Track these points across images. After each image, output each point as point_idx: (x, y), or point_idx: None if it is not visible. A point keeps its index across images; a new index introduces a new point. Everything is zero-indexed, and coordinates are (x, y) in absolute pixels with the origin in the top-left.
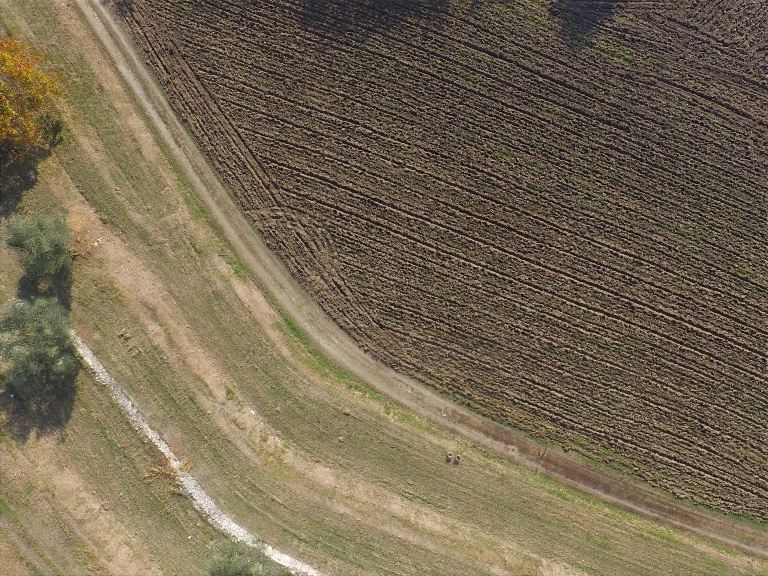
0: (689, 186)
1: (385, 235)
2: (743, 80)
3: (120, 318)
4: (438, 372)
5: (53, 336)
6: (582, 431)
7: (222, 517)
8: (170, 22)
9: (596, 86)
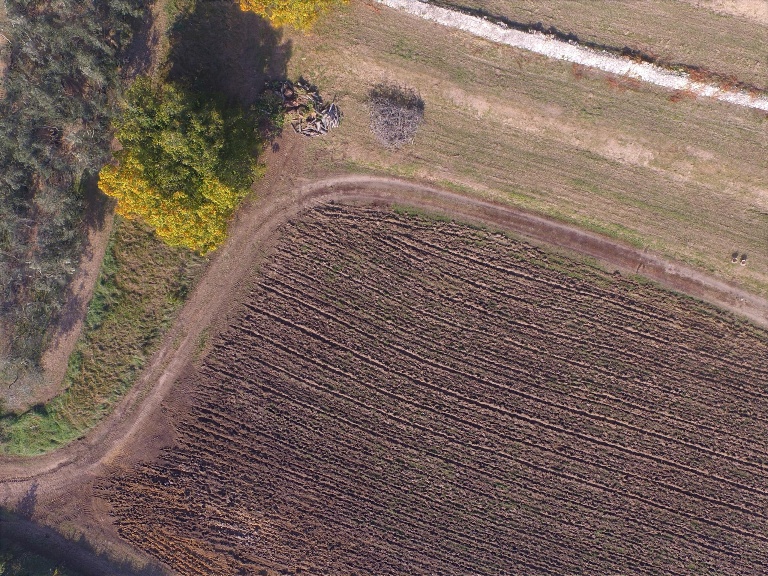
0: (508, 552)
1: None
2: None
3: None
4: (751, 342)
5: None
6: (602, 294)
7: None
8: None
9: None
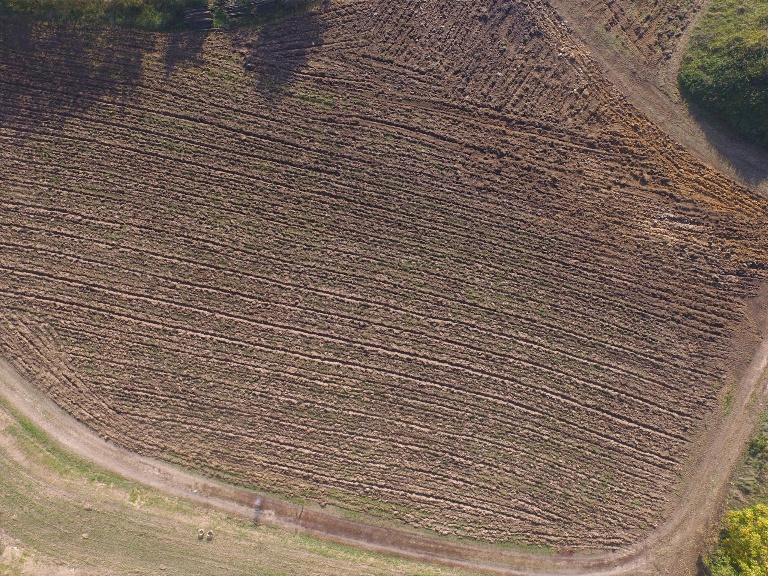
0: (405, 220)
1: (109, 320)
2: (444, 105)
3: None
4: (183, 449)
5: None
6: (336, 484)
7: None
8: None
9: (300, 135)
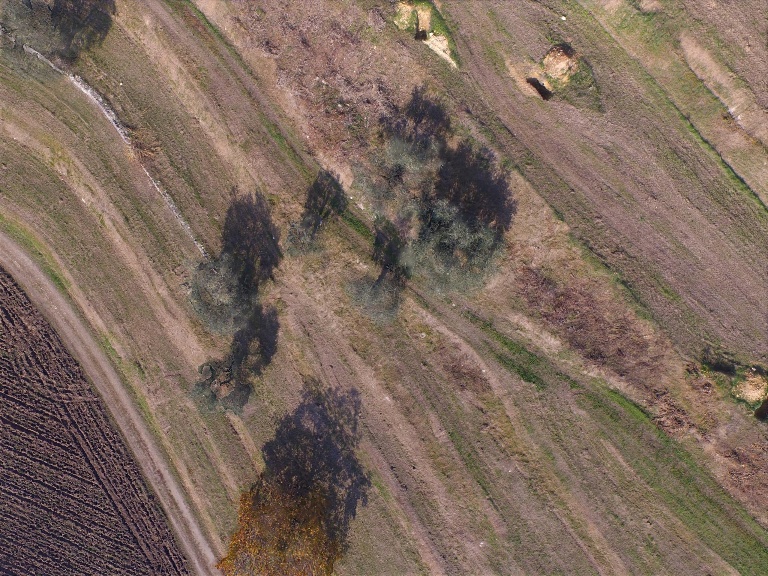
0: None
1: None
2: None
3: None
4: None
5: None
6: None
7: (95, 101)
8: None
9: None
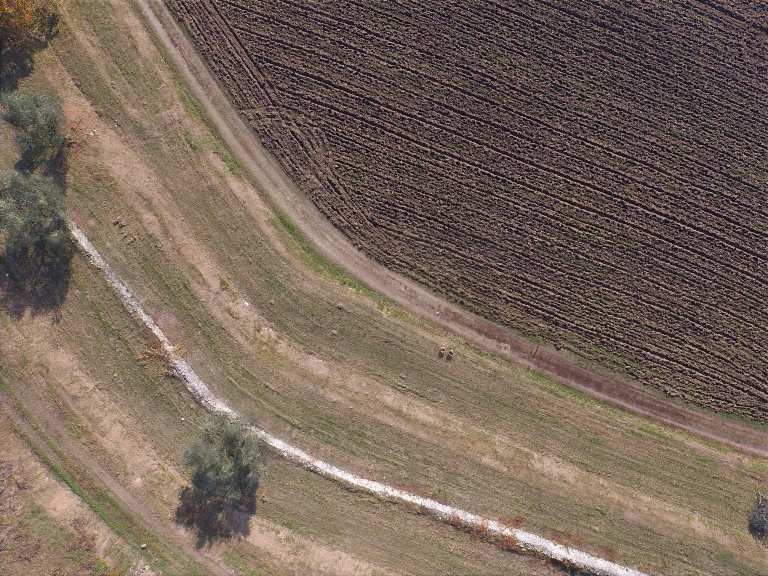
0: (682, 87)
1: (379, 134)
2: None
3: (115, 206)
4: (431, 270)
5: (48, 207)
6: (574, 329)
7: (215, 401)
8: None
9: None
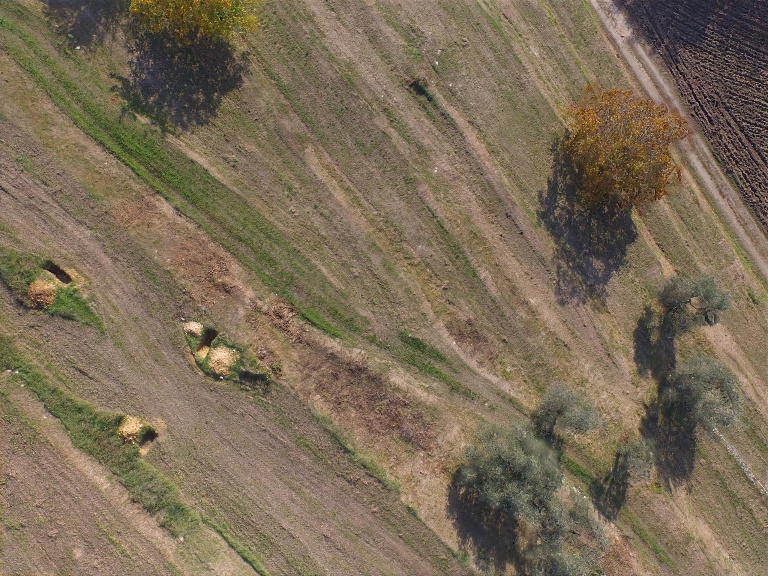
0: None
1: None
2: None
3: None
4: None
5: None
6: None
7: None
8: (715, 74)
9: None
